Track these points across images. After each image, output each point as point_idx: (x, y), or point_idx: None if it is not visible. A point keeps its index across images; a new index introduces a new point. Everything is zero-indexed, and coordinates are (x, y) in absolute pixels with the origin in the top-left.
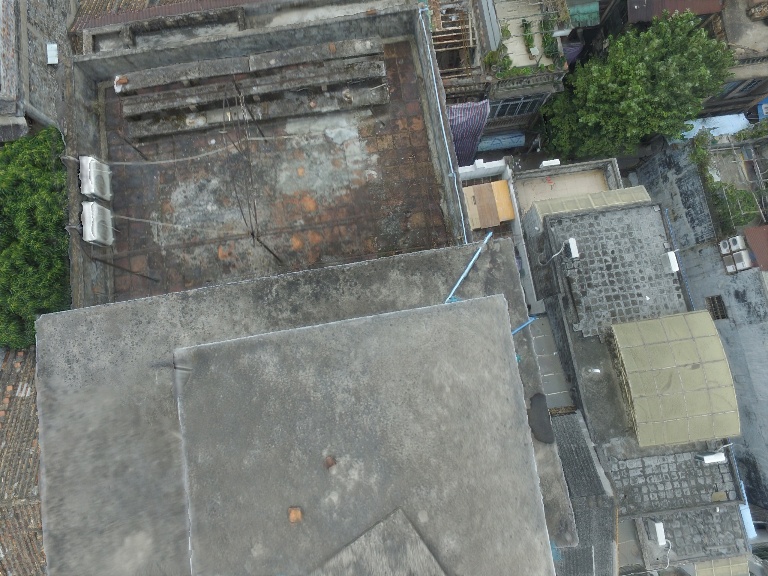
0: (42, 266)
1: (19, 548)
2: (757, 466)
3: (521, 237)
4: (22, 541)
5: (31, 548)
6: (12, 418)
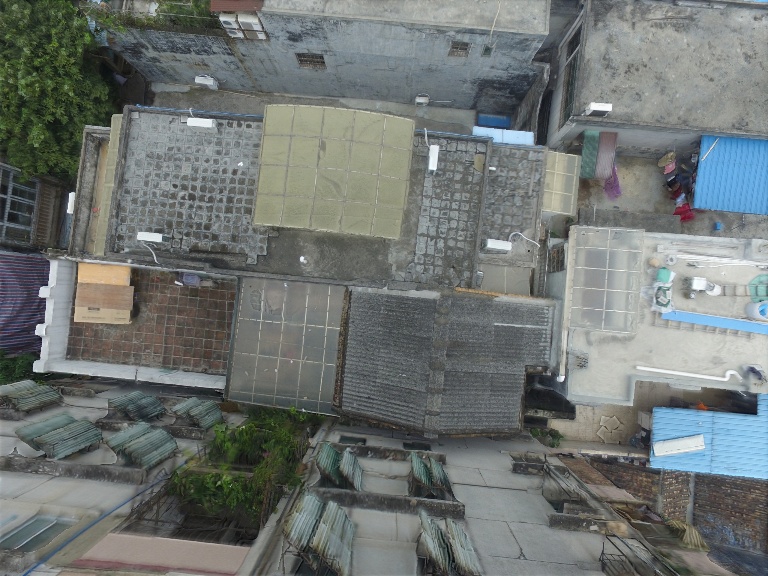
0: None
1: None
2: (487, 79)
3: None
4: None
5: None
6: None
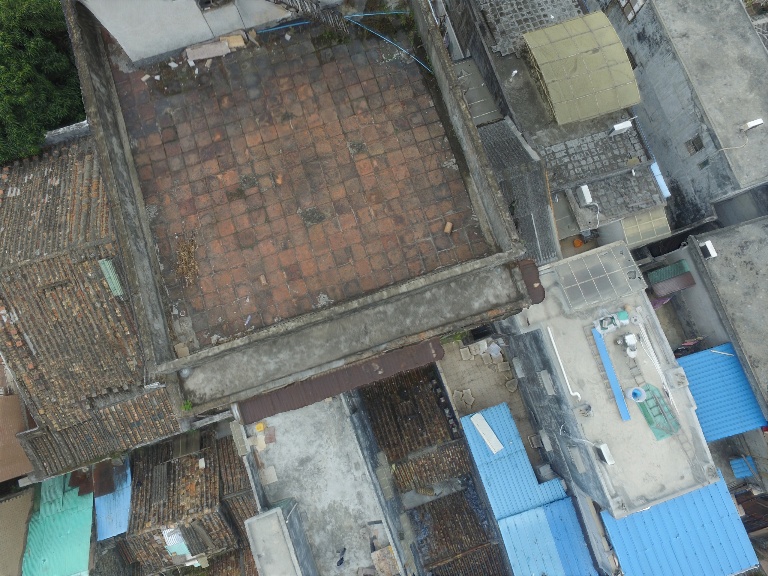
0: (13, 67)
1: (31, 309)
2: (680, 187)
3: (444, 11)
4: (33, 301)
5: (42, 307)
6: (7, 212)
